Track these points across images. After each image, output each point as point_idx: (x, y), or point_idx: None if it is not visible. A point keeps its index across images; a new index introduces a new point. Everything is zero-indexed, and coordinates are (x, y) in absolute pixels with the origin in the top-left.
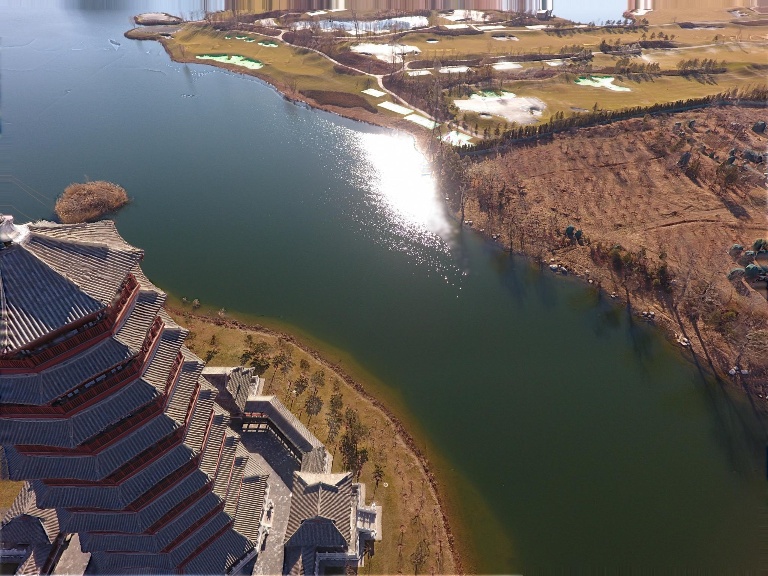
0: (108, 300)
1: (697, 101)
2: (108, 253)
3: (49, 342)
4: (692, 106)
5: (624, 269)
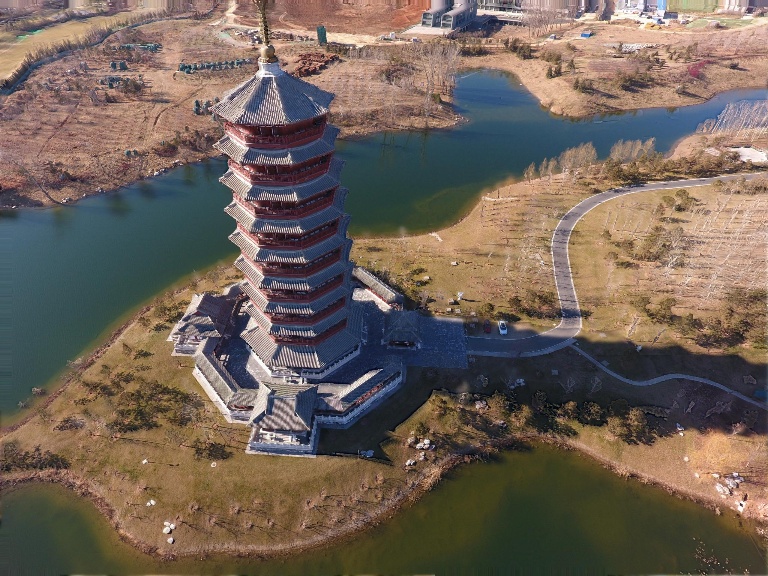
0: None
1: (22, 69)
2: None
3: None
4: (24, 74)
5: (183, 147)
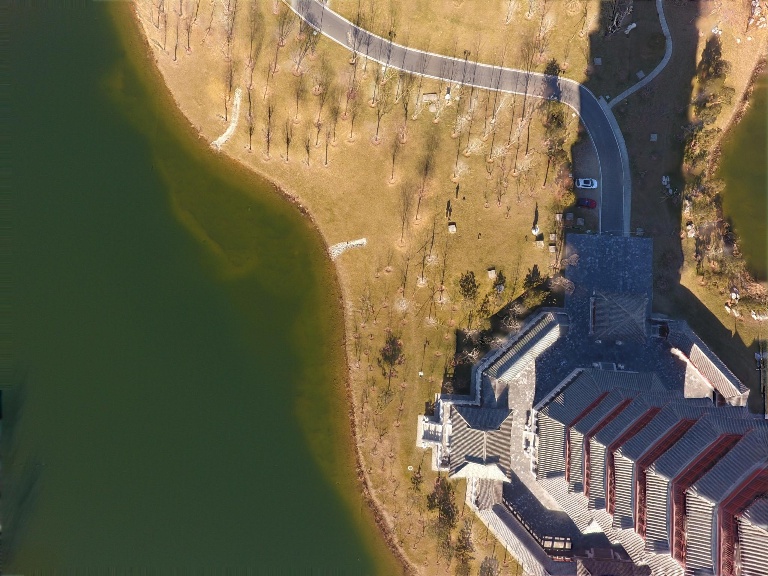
0: None
1: None
2: None
3: None
4: None
5: None
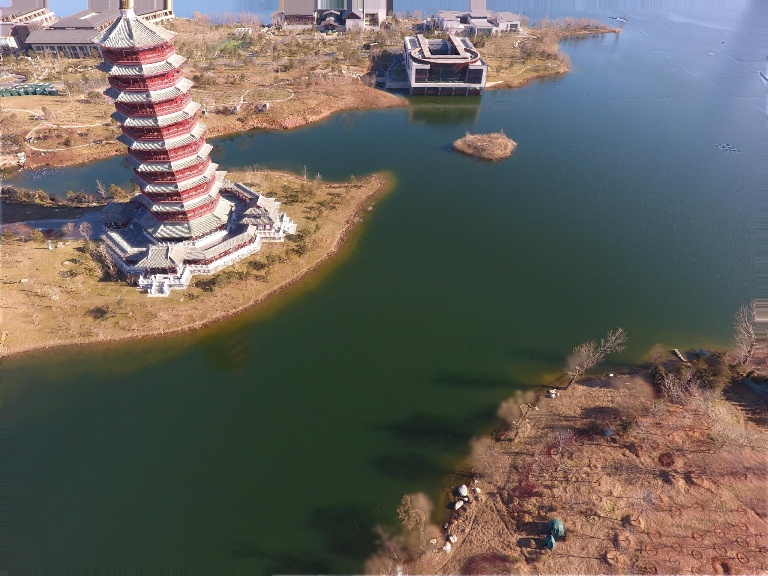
0: (105, 45)
1: None
2: (132, 39)
3: (111, 54)
4: None
5: None
